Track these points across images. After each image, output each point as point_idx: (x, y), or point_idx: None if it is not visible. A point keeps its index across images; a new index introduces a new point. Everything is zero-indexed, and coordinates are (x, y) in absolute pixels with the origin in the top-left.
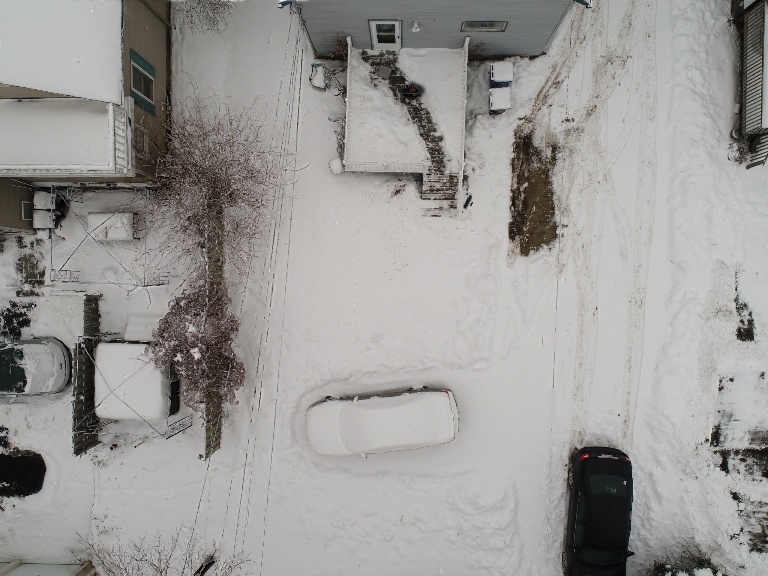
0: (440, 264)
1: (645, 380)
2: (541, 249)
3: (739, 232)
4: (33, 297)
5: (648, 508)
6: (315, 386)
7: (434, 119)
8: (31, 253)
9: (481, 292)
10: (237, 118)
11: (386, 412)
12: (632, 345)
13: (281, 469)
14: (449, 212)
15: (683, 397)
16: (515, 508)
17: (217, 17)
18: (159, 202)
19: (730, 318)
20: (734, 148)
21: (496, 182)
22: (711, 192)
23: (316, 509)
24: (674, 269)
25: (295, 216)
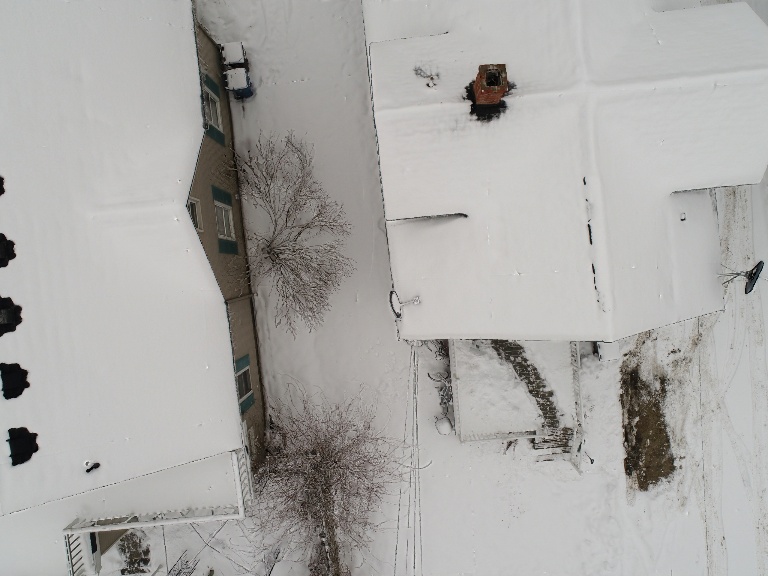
0: (558, 507)
1: None
2: (660, 482)
3: None
4: (138, 573)
5: None
6: None
7: (542, 375)
8: (132, 532)
9: (604, 534)
10: (346, 409)
11: None
12: (764, 571)
13: None
14: (562, 455)
15: None
16: None
17: (317, 317)
18: (274, 501)
19: None
20: None
21: (607, 420)
22: None
23: None
24: None
25: None
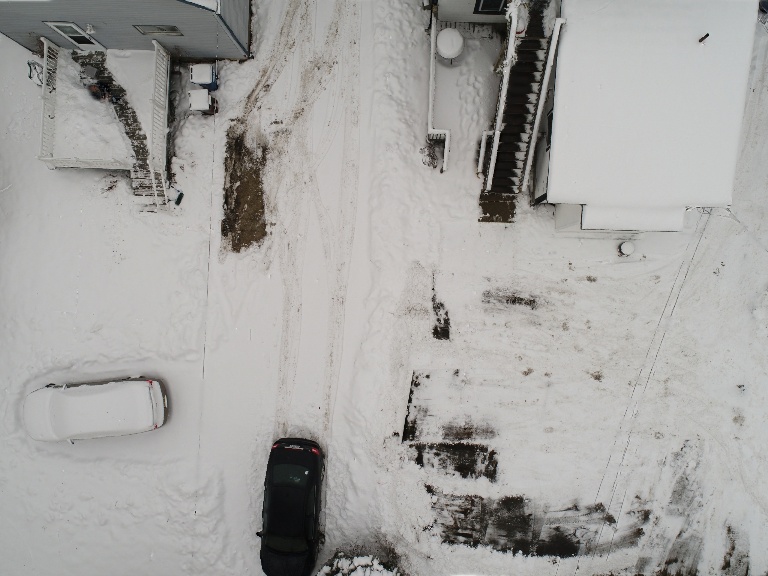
0: (156, 258)
1: (344, 375)
2: (251, 246)
3: (434, 234)
4: None
5: (345, 498)
6: (39, 374)
7: (138, 118)
8: None
9: (191, 286)
10: None
11: (84, 399)
12: (334, 341)
13: (5, 453)
14: (164, 208)
15: (376, 392)
16: (220, 496)
17: None
18: None
19: (425, 317)
20: (425, 153)
21: (209, 180)
22: (405, 195)
23: (36, 493)
24: (373, 268)
25: (22, 209)
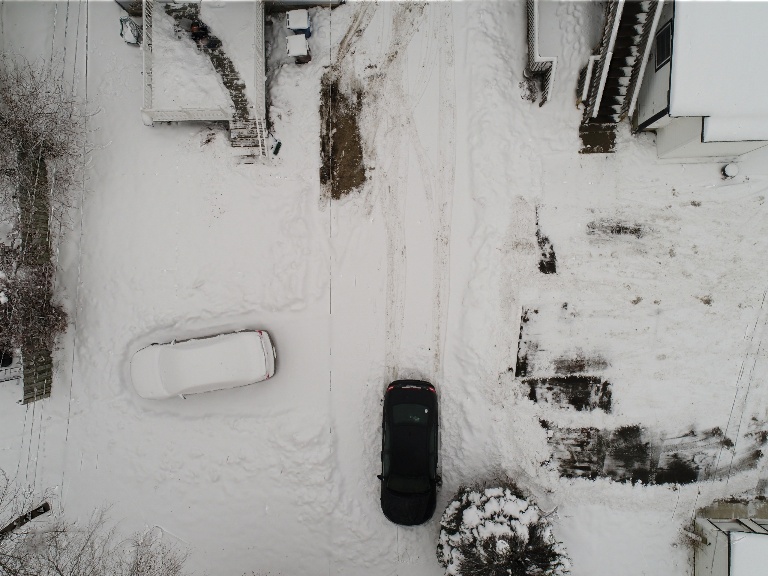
0: (255, 210)
1: (453, 314)
2: (351, 192)
3: (536, 168)
4: None
5: (460, 438)
6: (141, 333)
7: (236, 68)
8: None
9: (294, 235)
10: (39, 70)
11: (197, 351)
12: (440, 281)
13: (111, 415)
14: None
15: (487, 329)
16: (334, 444)
17: None
18: None
19: (531, 251)
20: (524, 87)
21: (305, 129)
22: (506, 130)
23: (145, 453)
24: (476, 206)
25: (117, 169)
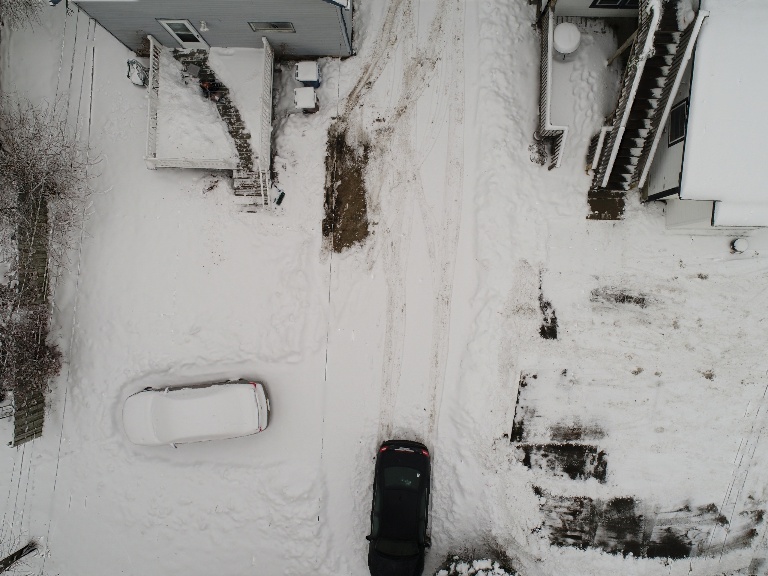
0: (256, 259)
1: (450, 376)
2: (353, 246)
3: (542, 232)
4: None
5: (452, 501)
6: (136, 377)
7: (242, 117)
8: None
9: (293, 287)
10: (43, 113)
11: (190, 403)
12: (439, 341)
13: (102, 458)
14: None
15: (484, 393)
16: (324, 499)
17: (18, 14)
18: None
19: (532, 316)
20: (534, 150)
21: (310, 180)
22: (513, 192)
23: (134, 497)
24: (479, 267)
25: (118, 210)
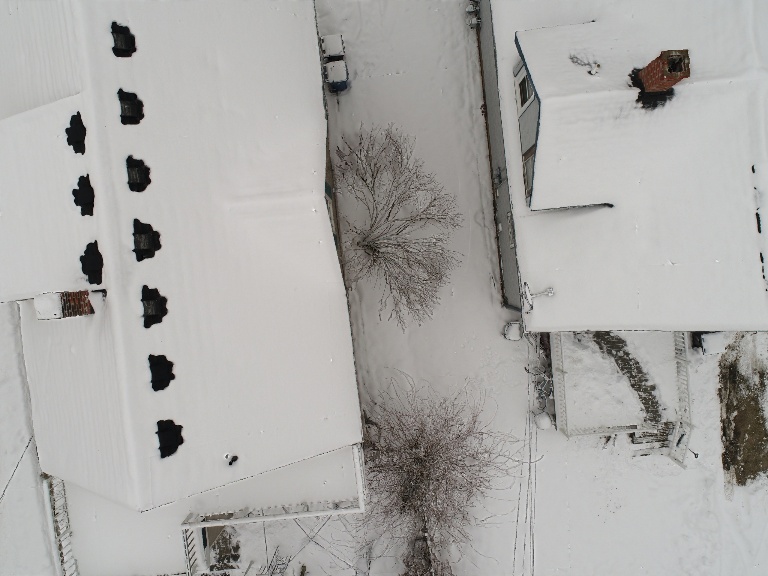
0: (655, 502)
1: None
2: (758, 477)
3: None
4: (227, 569)
5: None
6: None
7: (645, 369)
8: None
9: (703, 529)
10: (451, 403)
11: None
12: None
13: None
14: (659, 450)
15: None
16: None
17: (427, 310)
18: (378, 496)
19: None
20: None
21: (705, 414)
22: None
23: None
24: None
25: None
